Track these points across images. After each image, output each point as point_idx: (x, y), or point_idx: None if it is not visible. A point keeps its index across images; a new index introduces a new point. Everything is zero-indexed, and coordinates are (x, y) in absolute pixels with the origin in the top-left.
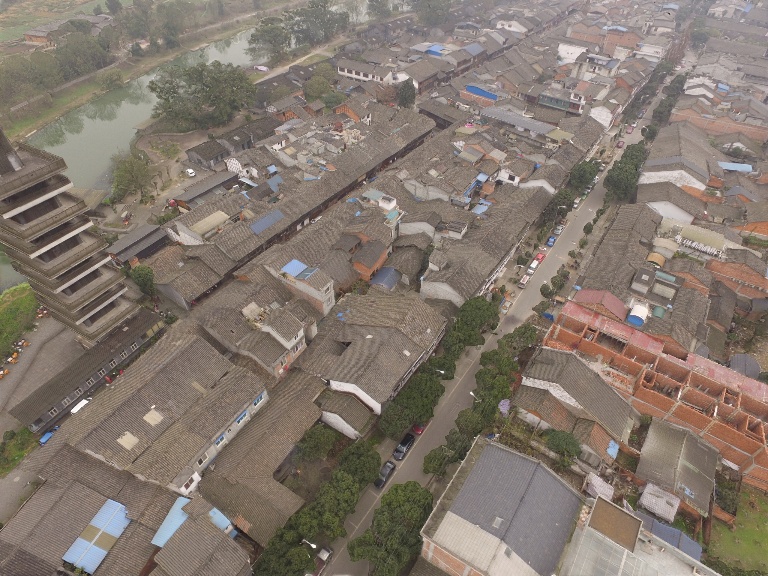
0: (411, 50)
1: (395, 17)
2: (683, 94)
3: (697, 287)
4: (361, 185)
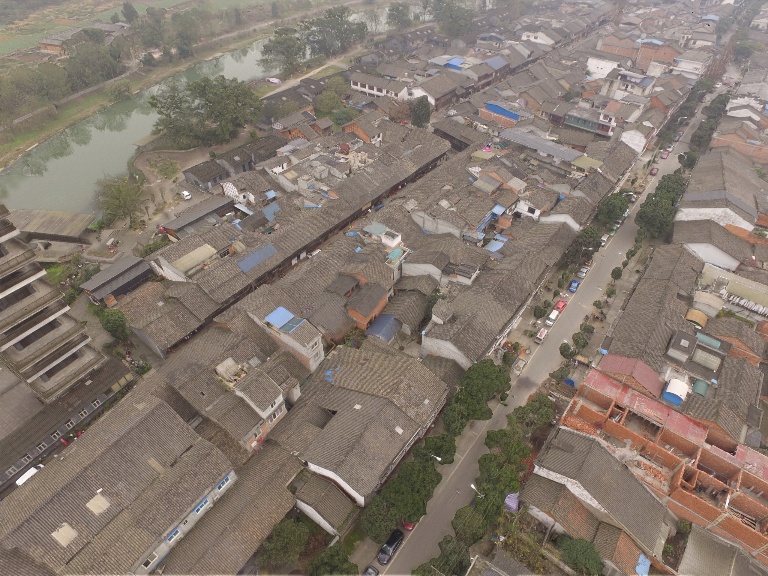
0: (429, 63)
1: (416, 27)
2: (725, 116)
3: (746, 355)
4: (366, 213)
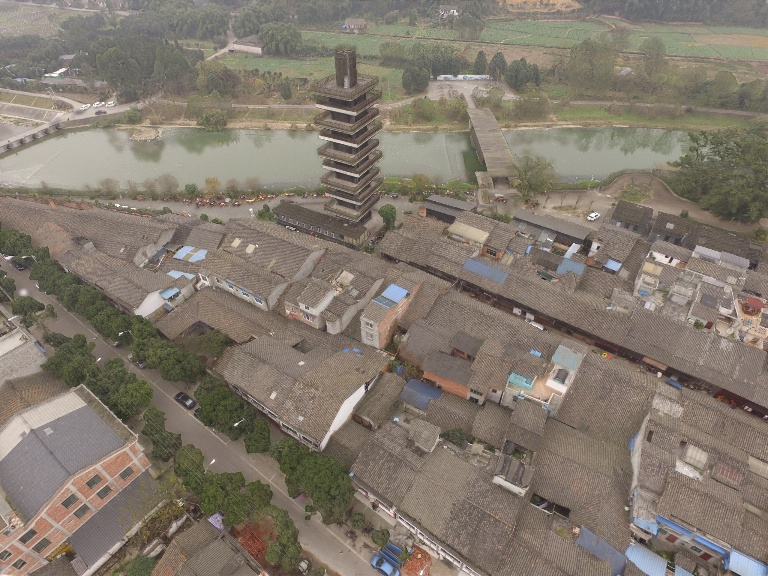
0: None
1: None
2: None
3: None
4: (650, 370)
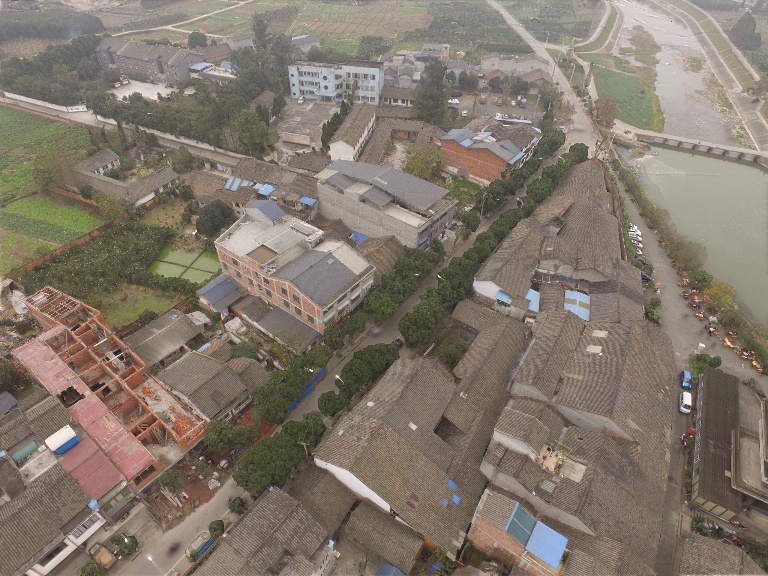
0: None
1: None
2: None
3: None
4: None
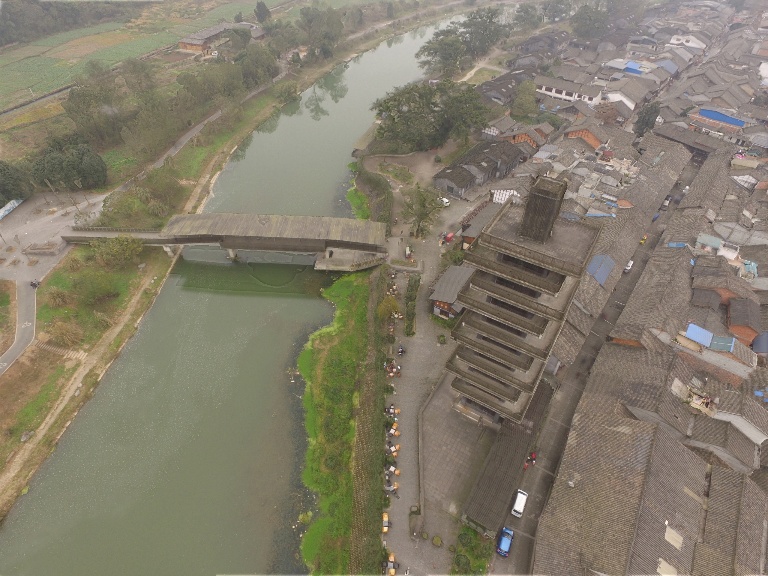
0: (603, 67)
1: None
2: None
3: None
4: None
